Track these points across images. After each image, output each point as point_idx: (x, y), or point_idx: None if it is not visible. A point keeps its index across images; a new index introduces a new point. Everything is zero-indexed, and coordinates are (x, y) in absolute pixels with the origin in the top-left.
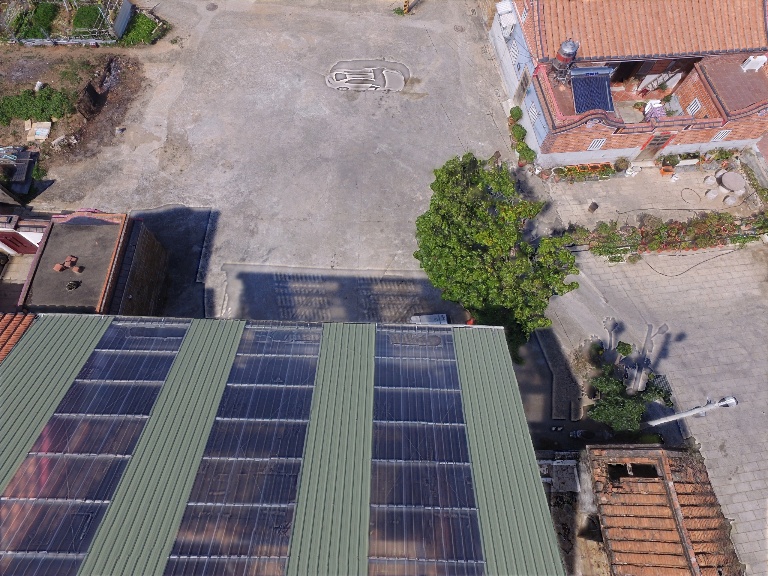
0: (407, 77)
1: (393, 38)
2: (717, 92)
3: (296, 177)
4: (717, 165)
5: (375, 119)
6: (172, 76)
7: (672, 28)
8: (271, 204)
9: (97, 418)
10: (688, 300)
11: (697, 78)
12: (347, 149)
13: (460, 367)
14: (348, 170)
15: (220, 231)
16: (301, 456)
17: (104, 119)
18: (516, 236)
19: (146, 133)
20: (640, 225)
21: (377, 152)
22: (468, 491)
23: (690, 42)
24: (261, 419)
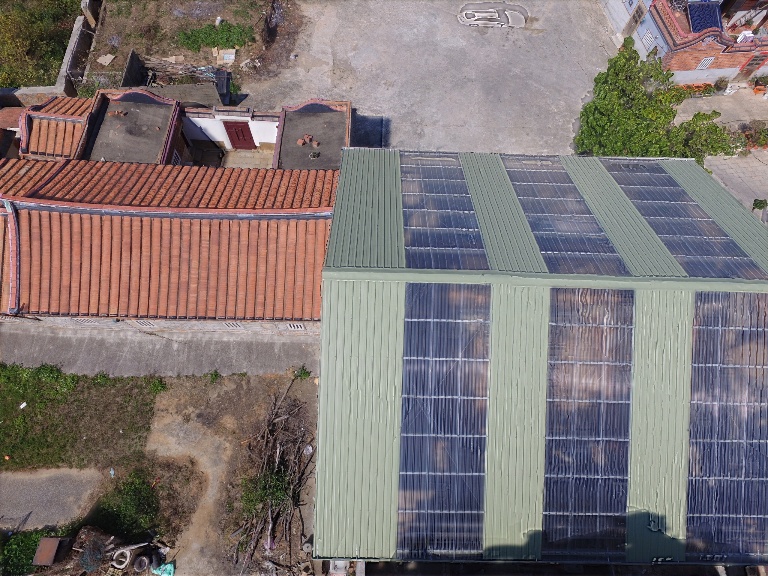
0: (526, 16)
1: None
2: None
3: (448, 93)
4: None
5: (506, 49)
6: (327, 15)
7: None
8: (431, 114)
9: (433, 196)
10: None
11: None
12: (487, 72)
13: (675, 178)
14: (491, 88)
15: (393, 134)
16: (592, 214)
17: (278, 47)
18: None
19: (315, 59)
20: (742, 132)
21: (512, 75)
22: (720, 231)
23: None
24: (550, 198)
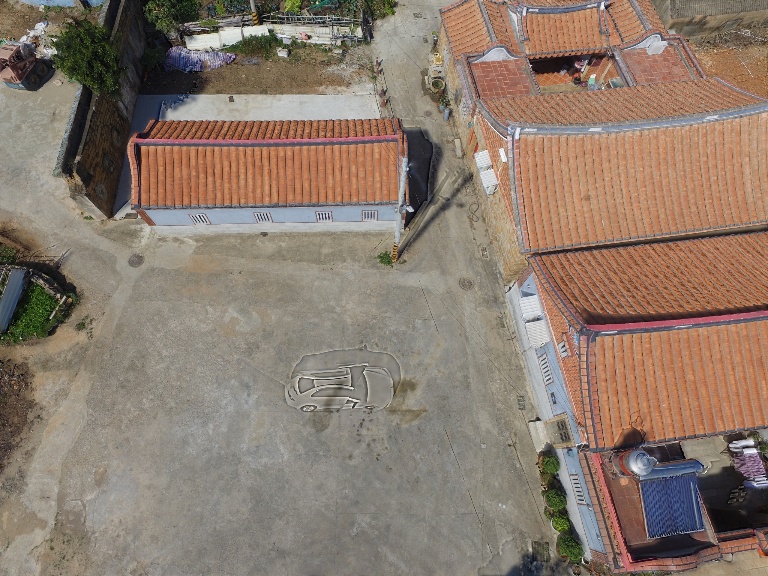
0: (397, 380)
1: (378, 308)
2: None
3: None
4: None
5: (353, 465)
6: (72, 397)
7: None
8: None
9: None
10: None
11: None
12: (312, 529)
13: None
14: (313, 573)
15: None
16: None
17: None
18: None
19: (26, 514)
20: None
21: (355, 533)
22: None
23: None
24: None
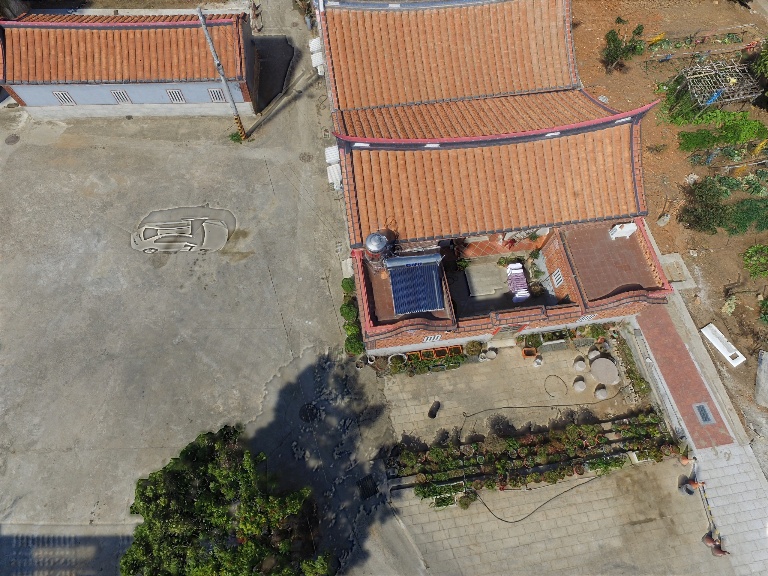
0: (232, 230)
1: (223, 175)
2: (576, 272)
3: (68, 385)
4: (592, 340)
5: (182, 293)
6: None
7: (519, 195)
8: (30, 428)
9: None
10: (529, 559)
11: (558, 246)
12: (140, 339)
13: None
14: (136, 371)
15: None
16: None
17: None
18: (244, 574)
19: None
20: (490, 432)
21: (177, 342)
22: None
23: (542, 211)
24: None
